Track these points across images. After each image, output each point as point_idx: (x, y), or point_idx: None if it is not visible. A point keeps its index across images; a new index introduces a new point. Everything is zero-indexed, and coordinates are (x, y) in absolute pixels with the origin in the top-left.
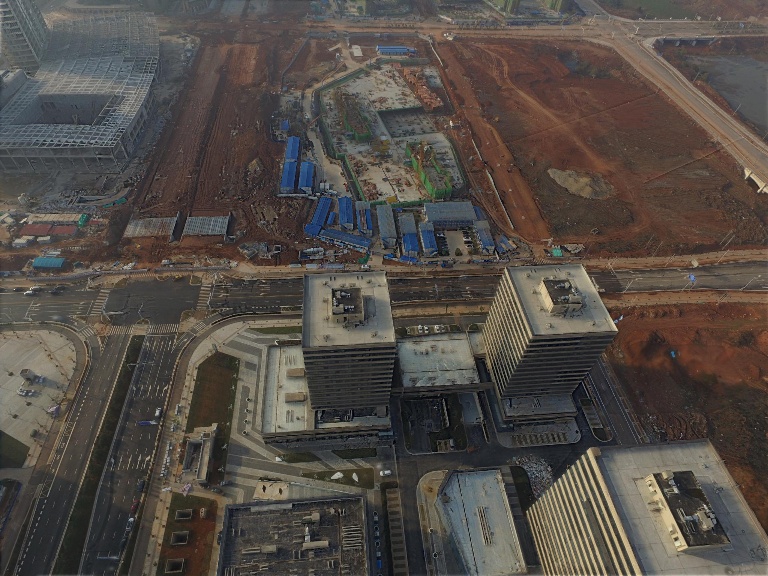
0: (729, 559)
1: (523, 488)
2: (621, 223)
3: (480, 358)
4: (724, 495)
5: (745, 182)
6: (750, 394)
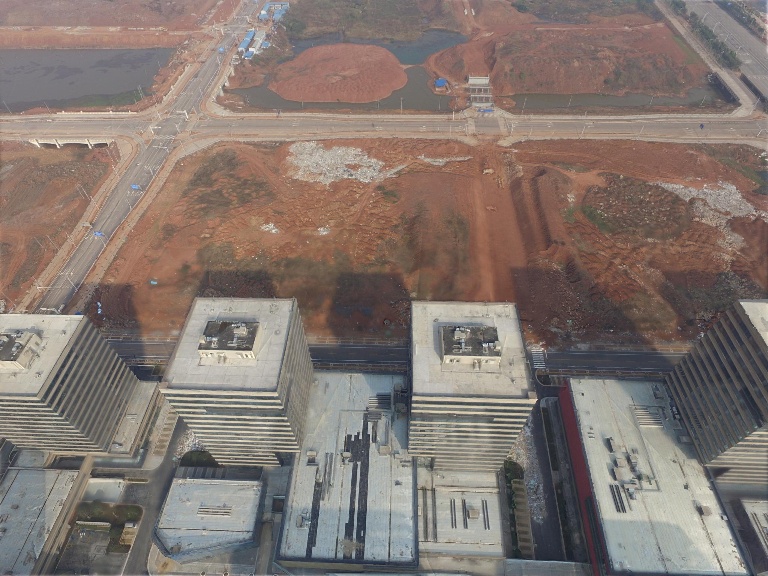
0: (271, 328)
1: (201, 460)
2: (3, 255)
3: (53, 461)
4: (235, 309)
5: (42, 149)
6: (207, 252)
